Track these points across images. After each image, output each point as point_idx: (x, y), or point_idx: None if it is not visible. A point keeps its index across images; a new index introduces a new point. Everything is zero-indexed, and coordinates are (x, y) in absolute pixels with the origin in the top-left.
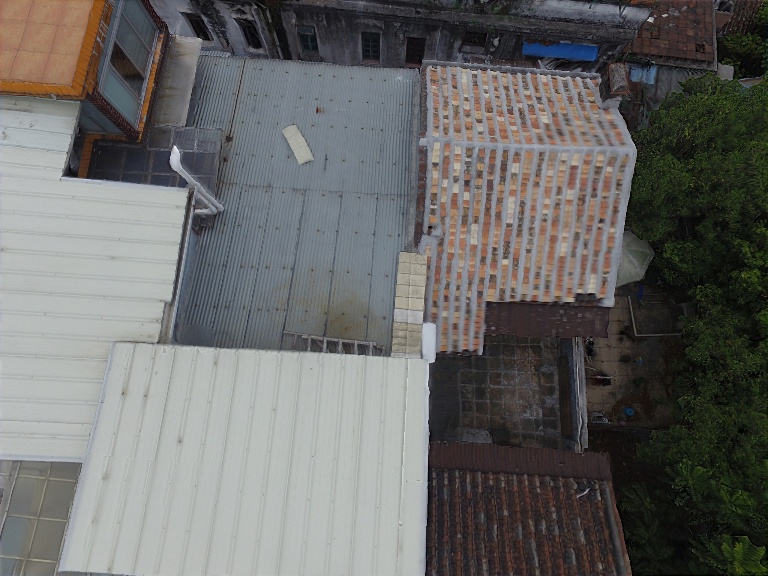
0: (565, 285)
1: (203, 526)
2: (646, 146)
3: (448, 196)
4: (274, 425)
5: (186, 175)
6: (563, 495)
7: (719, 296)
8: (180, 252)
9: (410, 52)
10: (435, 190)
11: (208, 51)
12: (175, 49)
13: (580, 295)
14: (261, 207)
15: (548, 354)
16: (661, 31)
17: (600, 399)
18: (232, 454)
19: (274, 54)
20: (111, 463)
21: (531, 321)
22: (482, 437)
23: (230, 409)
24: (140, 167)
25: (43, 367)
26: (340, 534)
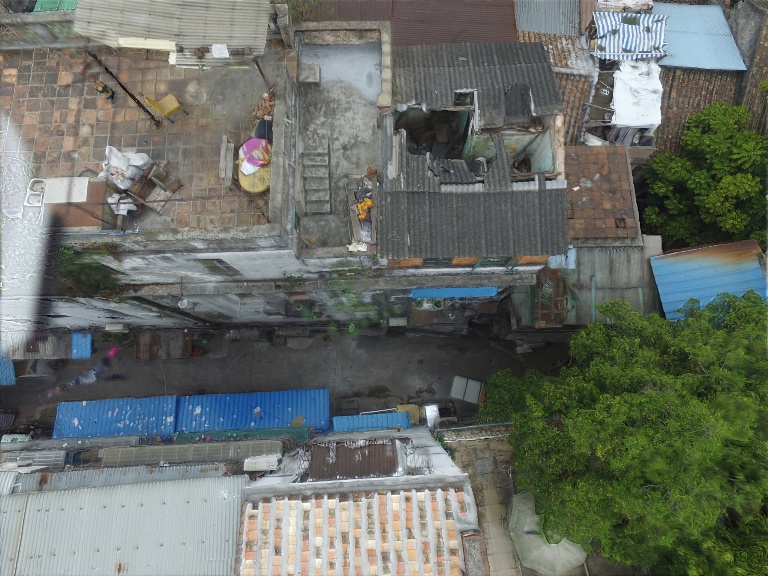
0: None
1: None
2: (565, 413)
3: None
4: None
5: None
6: None
7: None
8: None
9: None
10: None
11: None
12: None
13: None
14: None
15: None
16: (574, 208)
17: None
18: None
19: None
20: None
21: None
22: None
23: None
24: None
25: None
26: None
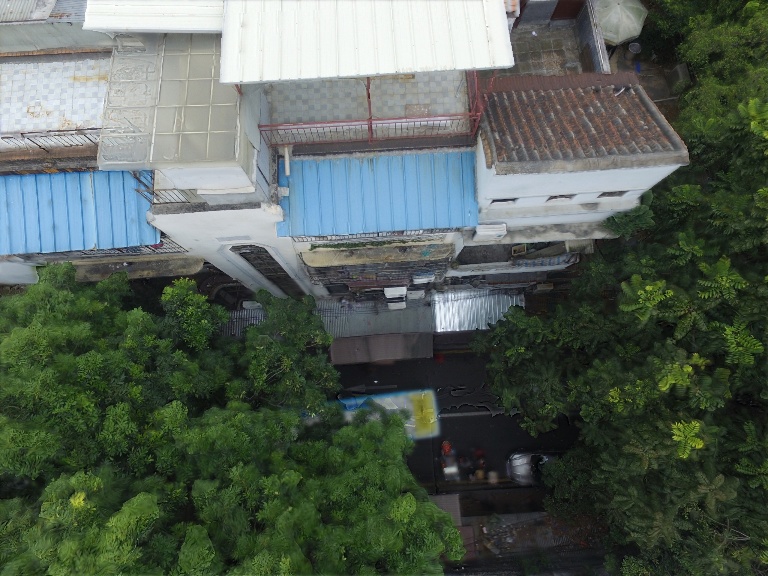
0: None
1: (330, 45)
2: None
3: None
4: None
5: None
6: (603, 96)
7: None
8: None
9: None
10: None
11: None
12: None
13: None
14: None
15: (570, 55)
16: None
17: None
18: (343, 1)
19: None
20: (246, 17)
21: None
22: None
23: None
24: None
25: None
26: (440, 38)
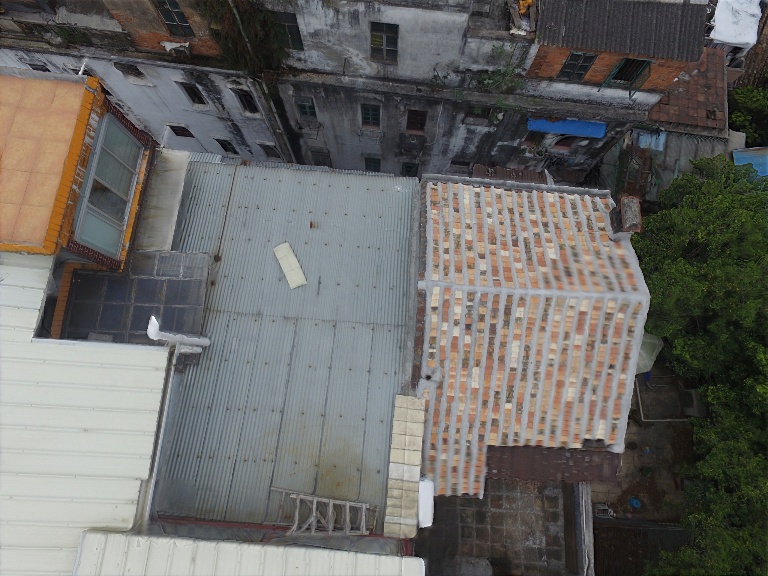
0: (572, 431)
1: None
2: (656, 234)
3: (448, 340)
4: None
5: (166, 337)
6: None
7: (732, 399)
8: (159, 420)
9: (411, 121)
10: (434, 334)
11: (198, 153)
12: (161, 164)
13: (588, 441)
14: (250, 339)
15: None
16: (671, 96)
17: (605, 488)
18: None
19: (271, 118)
20: None
21: (535, 464)
22: (482, 567)
23: None
24: (122, 297)
25: (7, 559)
26: None
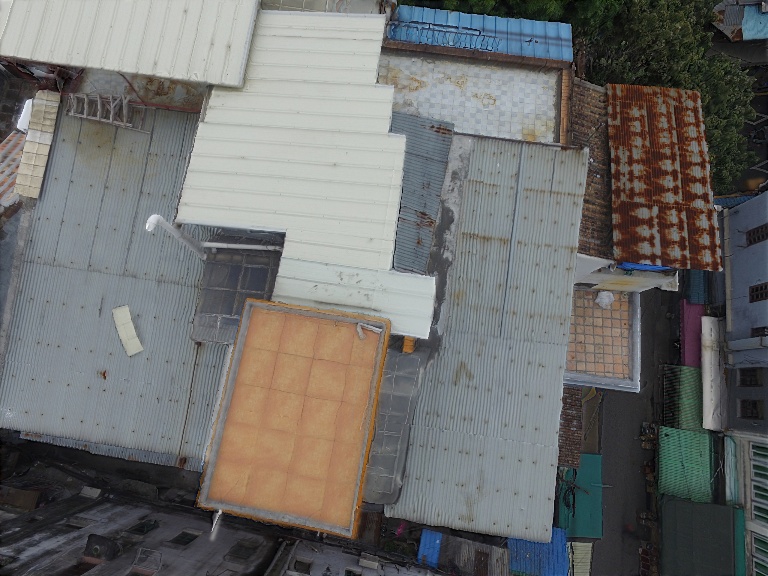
0: None
1: None
2: None
3: None
4: (113, 17)
5: None
6: None
7: None
8: None
9: None
10: None
11: None
12: None
13: None
14: (168, 259)
15: None
16: None
17: None
18: None
19: None
20: (237, 0)
21: None
22: None
23: (145, 30)
24: None
25: (299, 74)
26: None
